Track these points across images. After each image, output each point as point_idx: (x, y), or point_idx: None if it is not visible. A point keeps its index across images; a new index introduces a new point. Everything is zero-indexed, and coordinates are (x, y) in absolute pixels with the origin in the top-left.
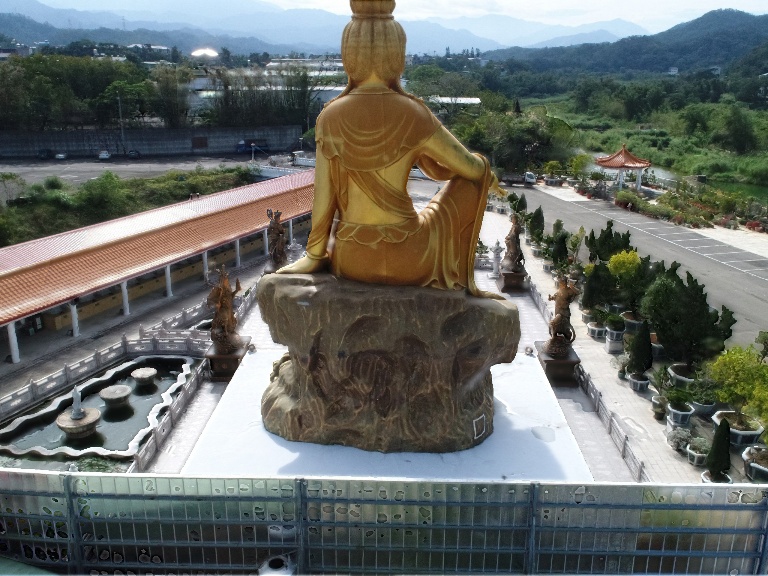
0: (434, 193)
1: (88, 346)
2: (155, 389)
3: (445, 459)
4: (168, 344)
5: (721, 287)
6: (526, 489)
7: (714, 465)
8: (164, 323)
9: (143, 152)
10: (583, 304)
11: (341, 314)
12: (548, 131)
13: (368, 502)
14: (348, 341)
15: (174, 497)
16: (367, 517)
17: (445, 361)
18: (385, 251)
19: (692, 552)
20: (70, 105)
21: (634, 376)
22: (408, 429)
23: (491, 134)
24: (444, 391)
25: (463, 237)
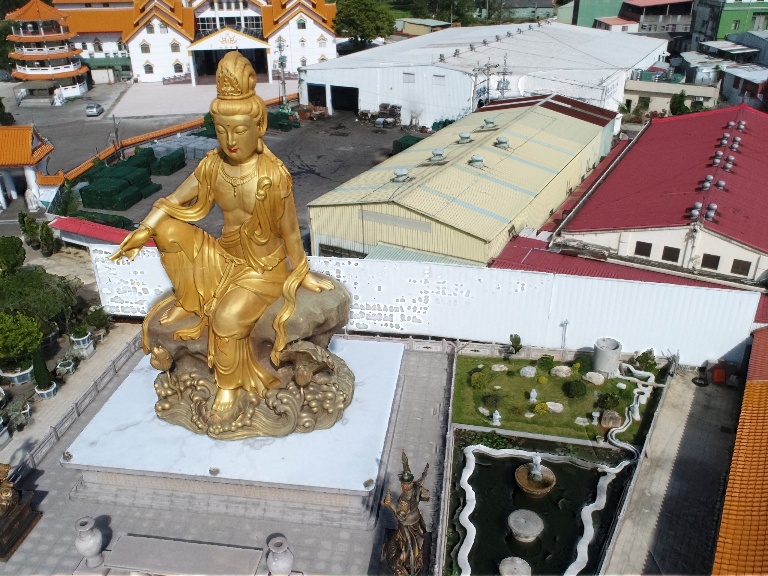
0: None
1: None
2: None
3: None
4: None
5: None
6: None
7: None
8: None
9: None
10: None
11: None
12: None
13: None
14: None
15: None
16: None
17: None
18: None
19: None
20: None
21: None
22: None
23: None
24: None
25: None
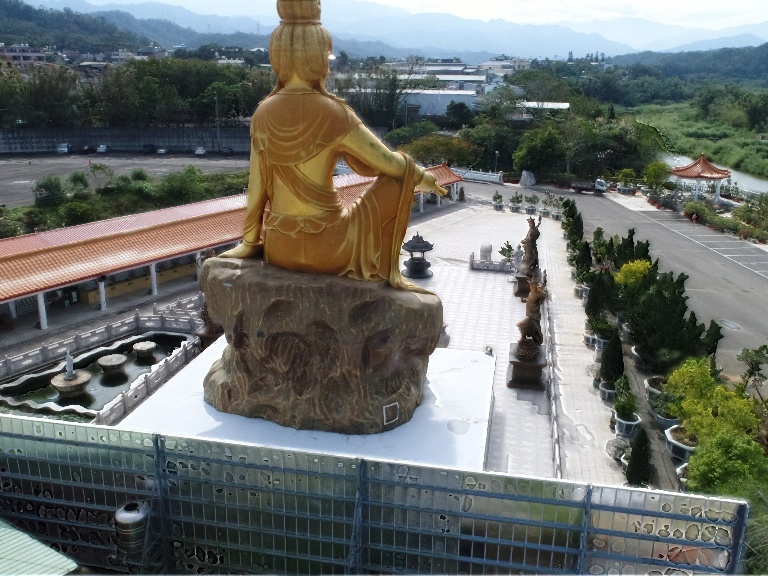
0: (492, 197)
1: (110, 319)
2: (154, 361)
3: (350, 440)
4: (174, 322)
5: (757, 305)
6: (353, 463)
7: (631, 474)
8: (179, 303)
9: (236, 149)
10: (586, 311)
11: (259, 296)
12: (637, 138)
13: (216, 461)
14: (266, 322)
15: (58, 441)
16: (216, 475)
17: (354, 347)
18: (304, 240)
19: (514, 542)
20: (174, 104)
21: (604, 384)
22: (319, 409)
23: (567, 140)
24: (353, 376)
25: (386, 231)
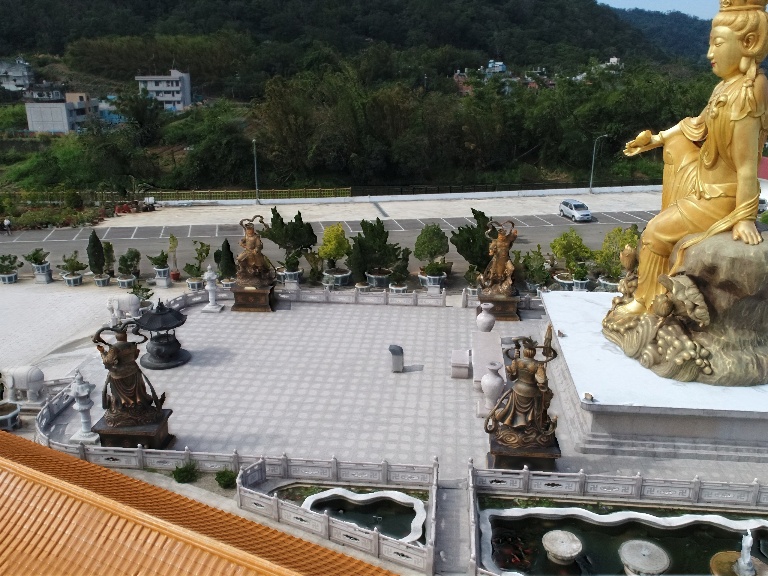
0: None
1: None
2: None
3: None
4: None
5: None
6: None
7: None
8: None
9: None
10: (363, 279)
11: None
12: None
13: None
14: None
15: None
16: None
17: None
18: None
19: None
20: None
21: None
22: None
23: None
24: None
25: None
